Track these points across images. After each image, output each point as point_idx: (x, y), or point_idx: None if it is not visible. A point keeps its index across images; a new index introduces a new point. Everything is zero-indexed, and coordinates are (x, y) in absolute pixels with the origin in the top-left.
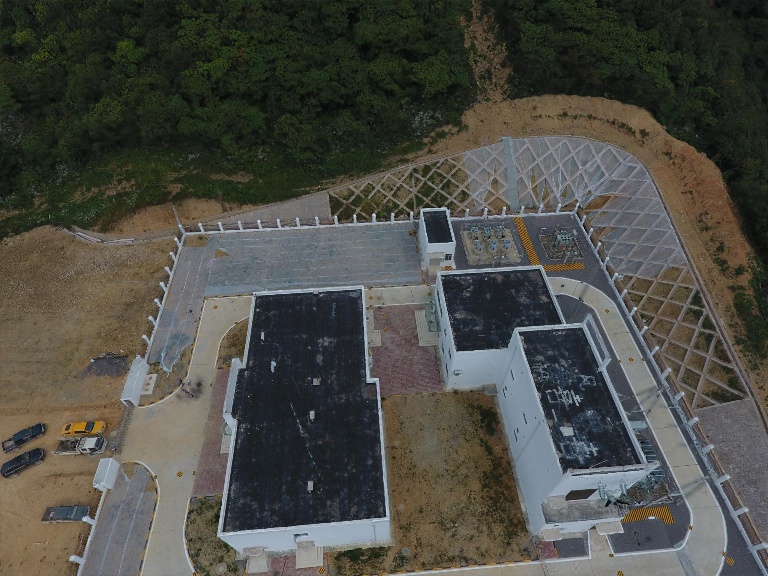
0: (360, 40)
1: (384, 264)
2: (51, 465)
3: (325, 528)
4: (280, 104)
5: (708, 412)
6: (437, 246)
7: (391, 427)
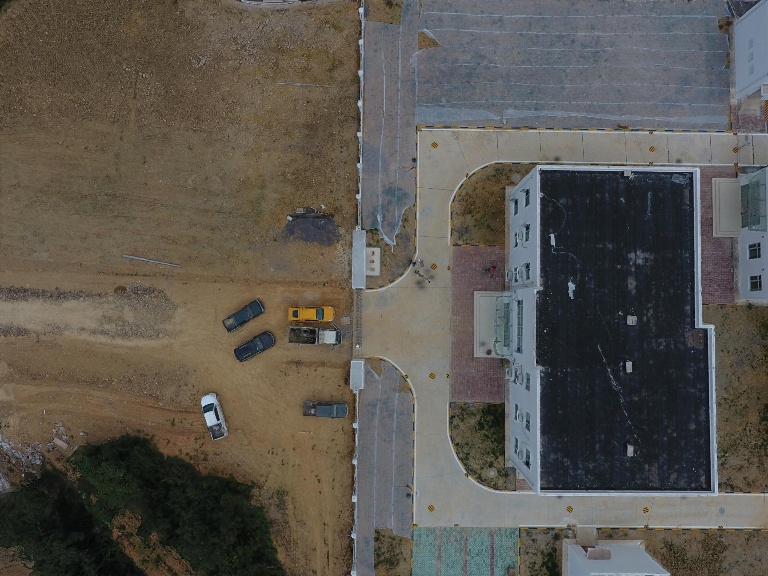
0: None
1: (675, 87)
2: (285, 350)
3: None
4: None
5: None
6: None
7: None
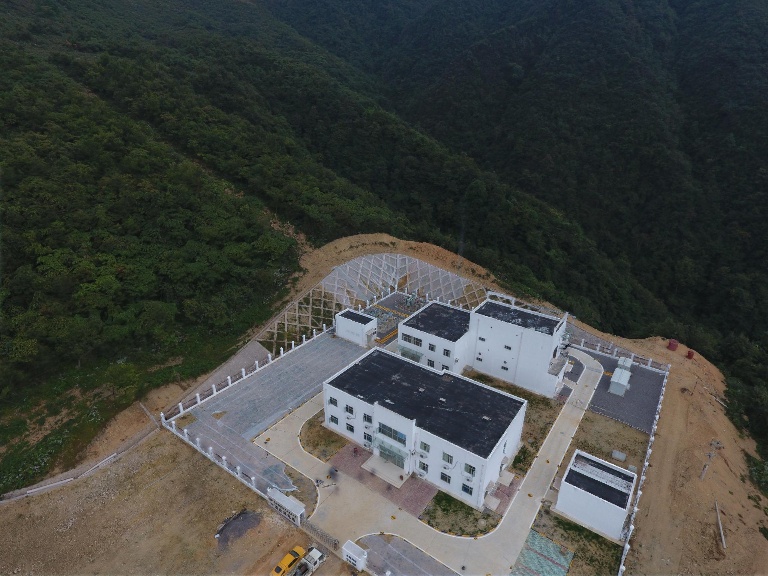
0: (206, 238)
1: (341, 357)
2: None
3: (513, 425)
4: (175, 294)
5: None
6: (369, 325)
7: None
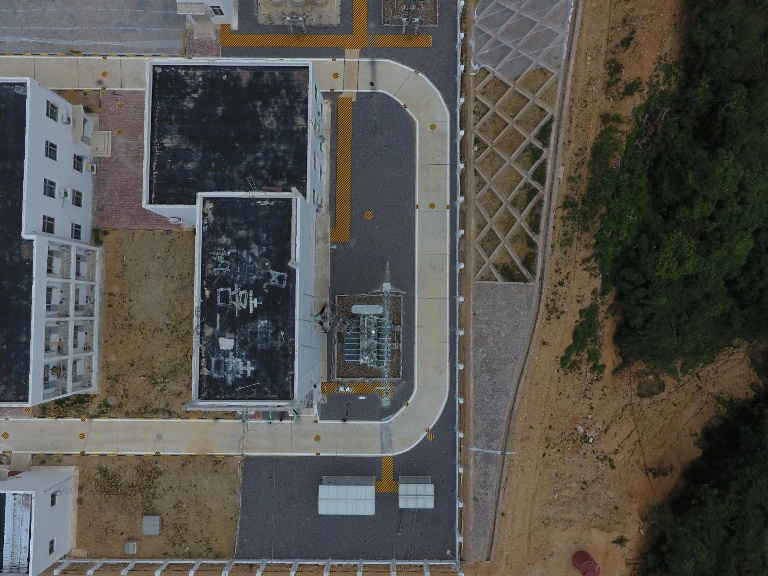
0: None
1: (129, 11)
2: None
3: None
4: None
5: (488, 288)
6: None
7: (111, 269)
